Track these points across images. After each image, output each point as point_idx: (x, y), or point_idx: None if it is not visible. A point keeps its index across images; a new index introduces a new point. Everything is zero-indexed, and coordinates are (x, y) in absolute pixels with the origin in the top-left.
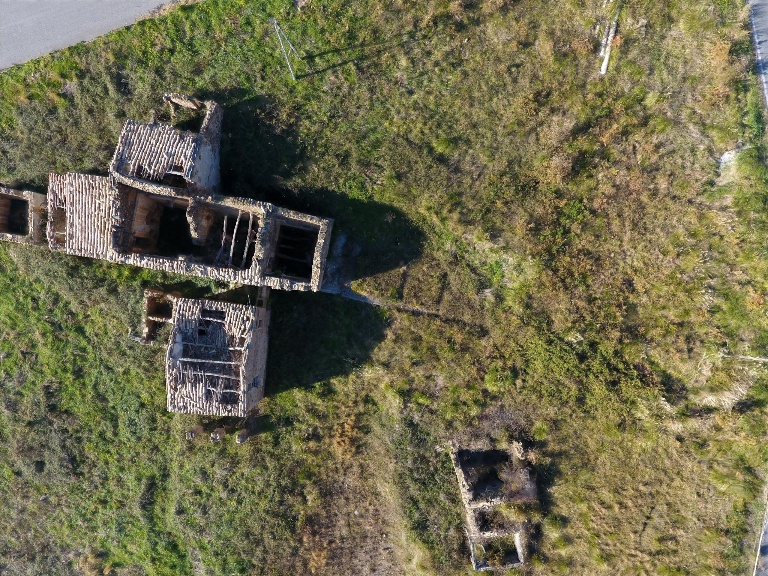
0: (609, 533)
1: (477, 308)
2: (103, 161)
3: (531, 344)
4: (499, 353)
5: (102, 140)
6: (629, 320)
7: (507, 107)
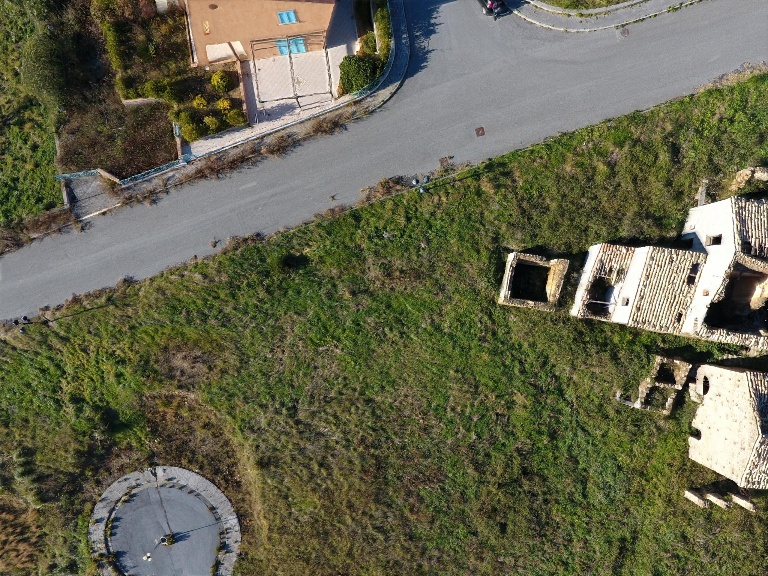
0: None
1: None
2: None
3: None
4: None
5: (641, 208)
6: None
7: None
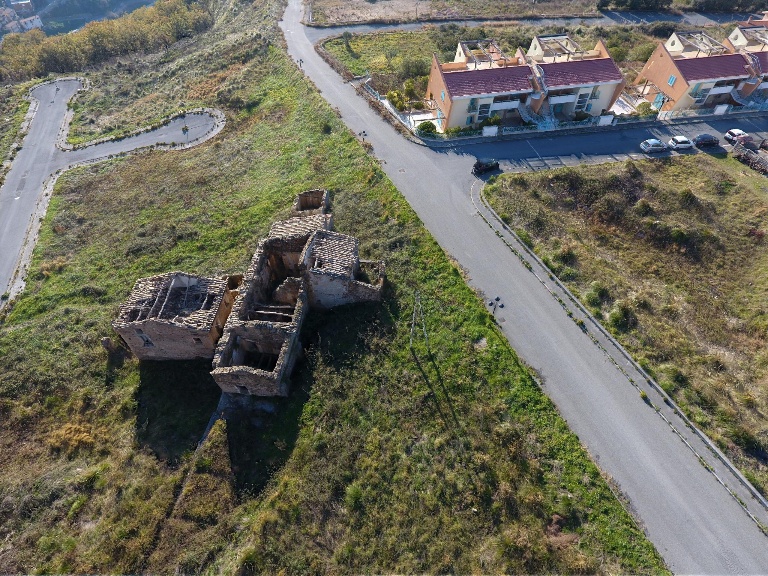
0: None
1: (164, 567)
2: None
3: None
4: None
5: None
6: None
7: (403, 574)
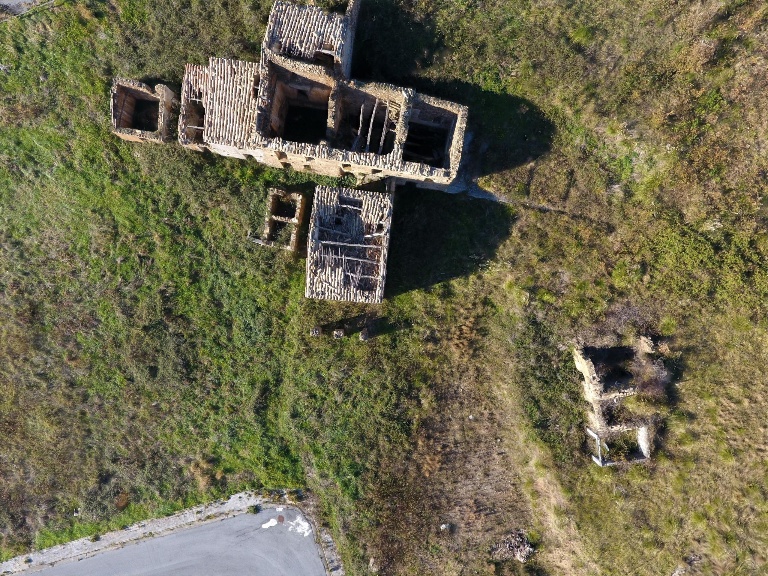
0: (738, 428)
1: (604, 204)
2: (236, 54)
3: (662, 237)
4: (627, 249)
5: (235, 33)
6: (762, 213)
7: None
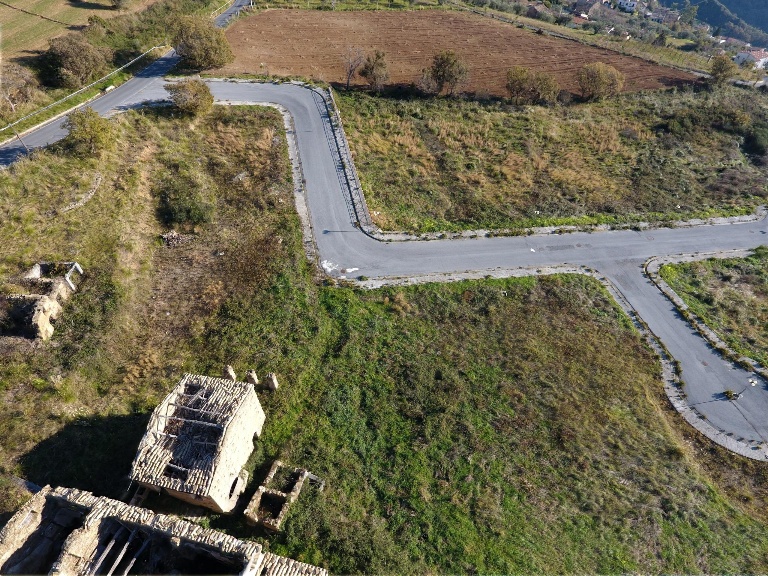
0: None
1: None
2: None
3: None
4: None
5: None
6: None
7: None
